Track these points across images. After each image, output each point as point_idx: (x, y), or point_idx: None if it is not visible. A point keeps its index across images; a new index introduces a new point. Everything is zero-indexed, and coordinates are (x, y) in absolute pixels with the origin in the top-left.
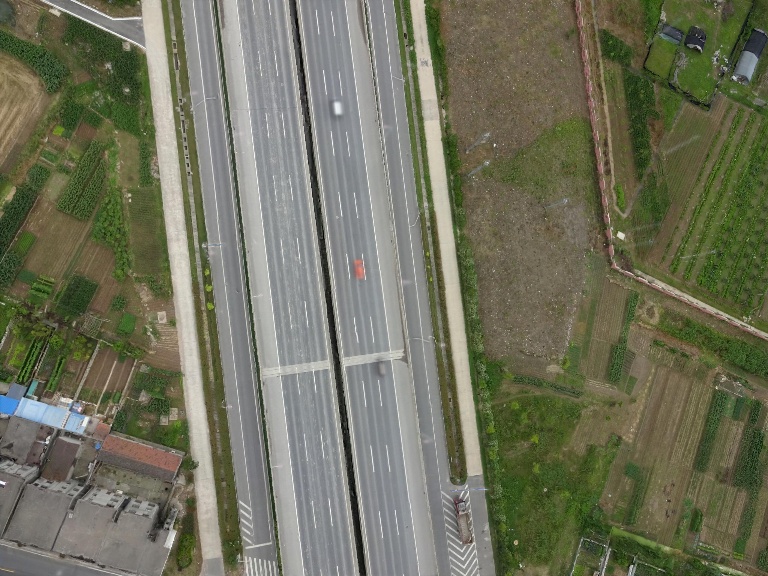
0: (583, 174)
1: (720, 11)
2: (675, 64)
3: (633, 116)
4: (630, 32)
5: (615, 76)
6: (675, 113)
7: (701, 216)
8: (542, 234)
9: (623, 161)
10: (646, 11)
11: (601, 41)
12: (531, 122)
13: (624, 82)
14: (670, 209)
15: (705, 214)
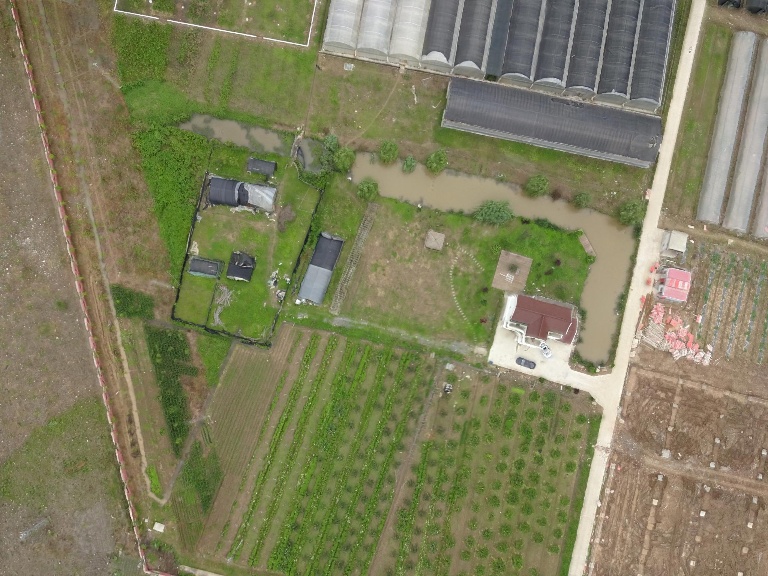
0: (100, 465)
1: (275, 220)
2: (215, 303)
3: (160, 381)
4: (151, 278)
5: (136, 336)
6: (222, 362)
7: (268, 483)
8: (42, 552)
9: (155, 436)
10: (168, 249)
11: (113, 299)
12: (17, 423)
13: (146, 341)
14: (224, 482)
15: (273, 480)
